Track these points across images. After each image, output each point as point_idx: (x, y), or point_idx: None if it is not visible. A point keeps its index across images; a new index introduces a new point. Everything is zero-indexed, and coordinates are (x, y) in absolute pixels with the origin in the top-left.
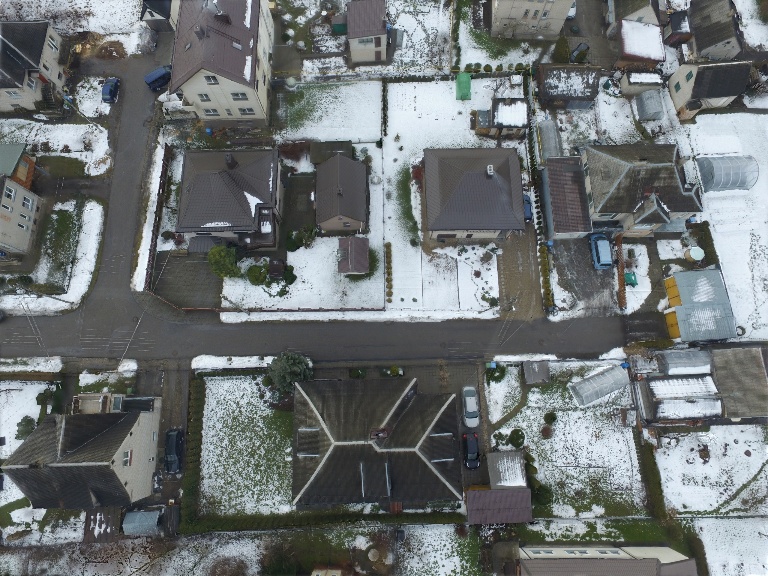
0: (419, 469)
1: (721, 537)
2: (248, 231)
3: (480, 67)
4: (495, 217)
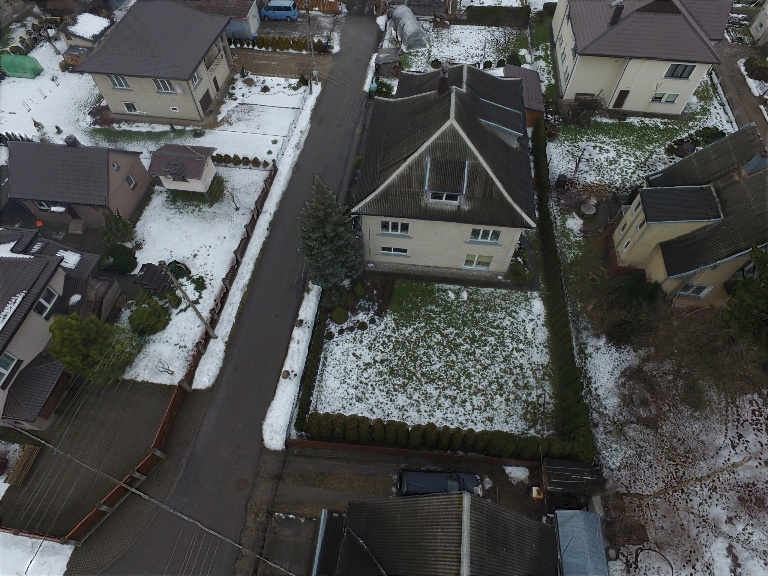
0: (488, 82)
1: (541, 2)
2: (56, 287)
3: (8, 51)
4: (204, 27)
